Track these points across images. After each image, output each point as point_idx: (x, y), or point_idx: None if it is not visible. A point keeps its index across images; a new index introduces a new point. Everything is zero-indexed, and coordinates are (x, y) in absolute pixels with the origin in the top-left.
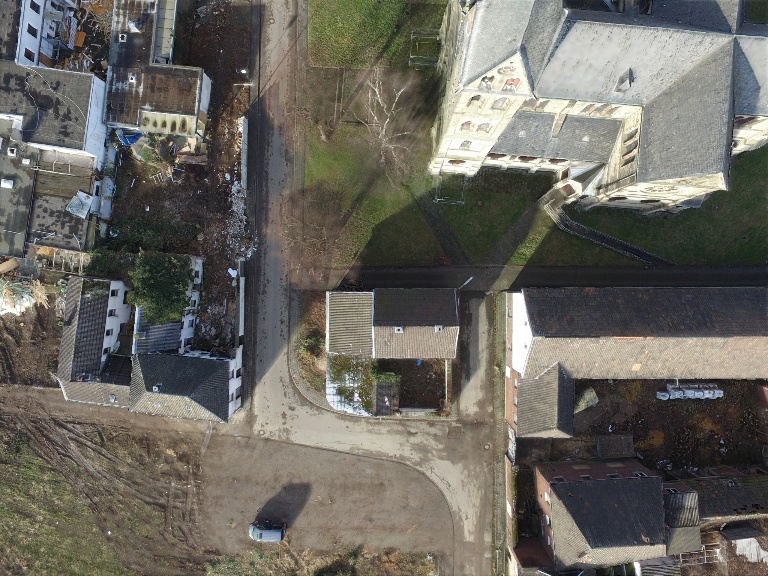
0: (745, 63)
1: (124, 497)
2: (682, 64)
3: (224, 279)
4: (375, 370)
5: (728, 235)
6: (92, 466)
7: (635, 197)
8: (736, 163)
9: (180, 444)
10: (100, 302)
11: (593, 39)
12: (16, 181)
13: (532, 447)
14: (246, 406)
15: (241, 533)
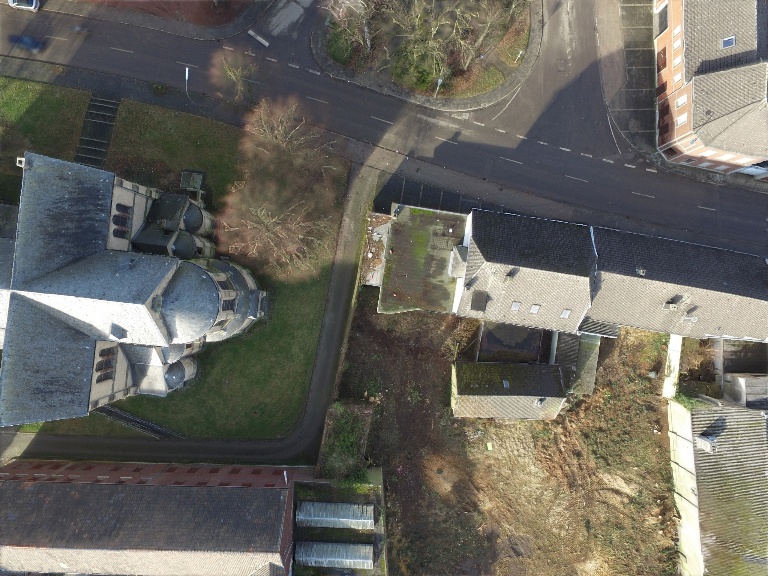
0: (52, 308)
1: None
2: None
3: None
4: None
5: (238, 409)
6: None
7: None
8: (246, 339)
9: None
10: None
11: None
12: None
13: None
14: None
15: None
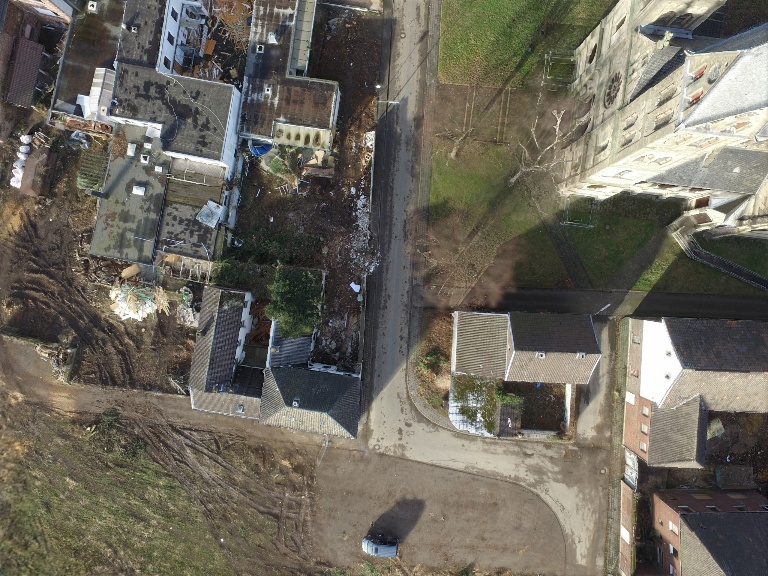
0: None
1: (238, 505)
2: None
3: (346, 293)
4: (501, 391)
5: None
6: (207, 473)
7: None
8: None
9: (295, 455)
10: (235, 314)
11: None
12: (147, 188)
13: (649, 473)
14: (362, 420)
15: (353, 546)
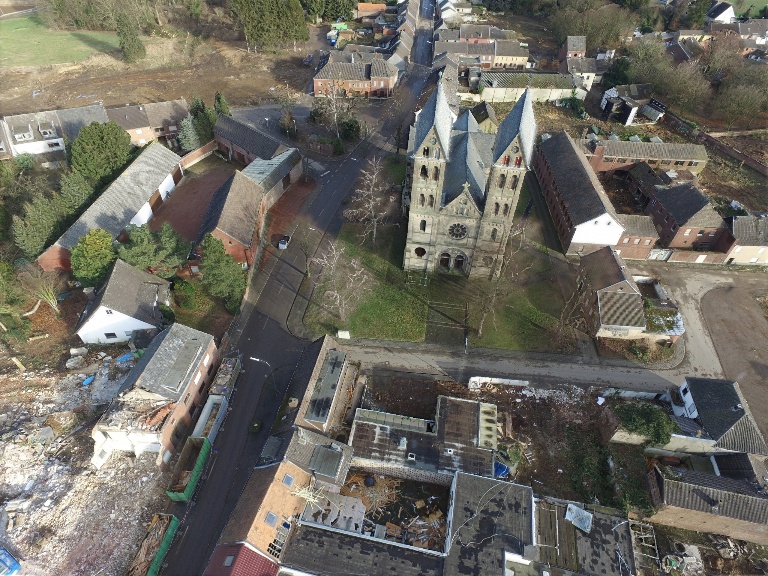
0: None
1: None
2: None
3: None
4: (646, 305)
5: None
6: None
7: None
8: None
9: None
10: None
11: None
12: None
13: None
14: None
15: None
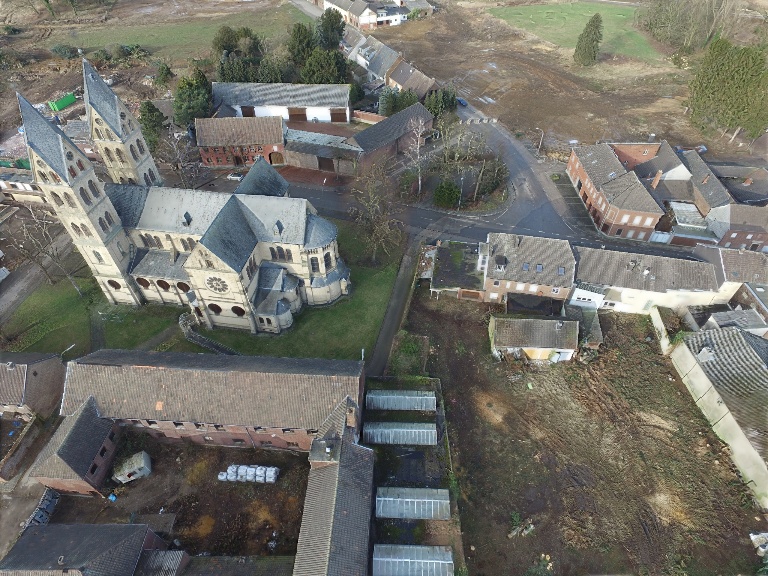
0: (247, 209)
1: None
2: (214, 210)
3: None
4: None
5: (319, 352)
6: None
7: (218, 301)
8: (332, 308)
9: None
10: None
11: (162, 196)
12: None
13: None
14: None
15: None
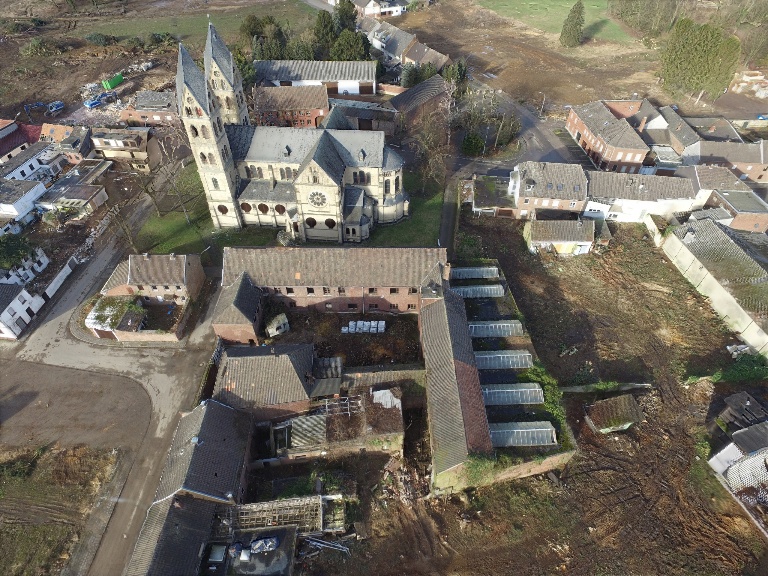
0: (337, 141)
1: None
2: (310, 143)
3: None
4: (129, 302)
5: None
6: None
7: (315, 215)
8: (398, 225)
9: None
10: None
11: (266, 133)
12: None
13: None
14: (22, 339)
15: None
